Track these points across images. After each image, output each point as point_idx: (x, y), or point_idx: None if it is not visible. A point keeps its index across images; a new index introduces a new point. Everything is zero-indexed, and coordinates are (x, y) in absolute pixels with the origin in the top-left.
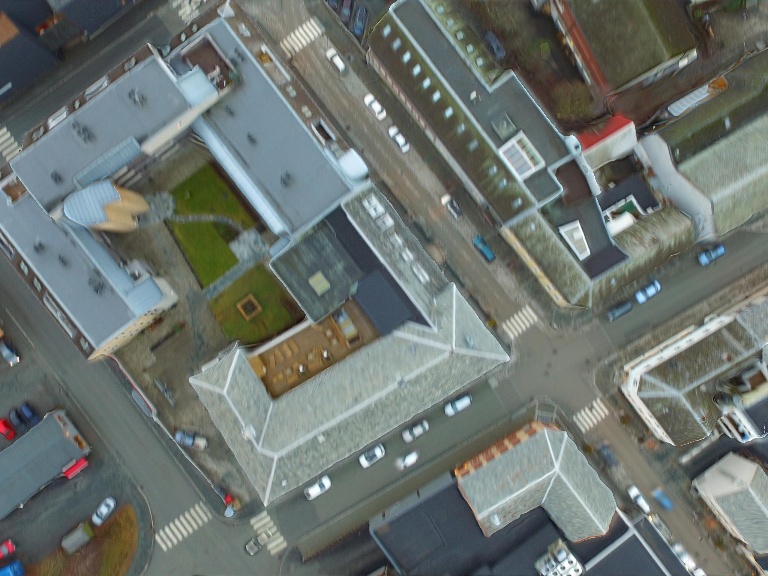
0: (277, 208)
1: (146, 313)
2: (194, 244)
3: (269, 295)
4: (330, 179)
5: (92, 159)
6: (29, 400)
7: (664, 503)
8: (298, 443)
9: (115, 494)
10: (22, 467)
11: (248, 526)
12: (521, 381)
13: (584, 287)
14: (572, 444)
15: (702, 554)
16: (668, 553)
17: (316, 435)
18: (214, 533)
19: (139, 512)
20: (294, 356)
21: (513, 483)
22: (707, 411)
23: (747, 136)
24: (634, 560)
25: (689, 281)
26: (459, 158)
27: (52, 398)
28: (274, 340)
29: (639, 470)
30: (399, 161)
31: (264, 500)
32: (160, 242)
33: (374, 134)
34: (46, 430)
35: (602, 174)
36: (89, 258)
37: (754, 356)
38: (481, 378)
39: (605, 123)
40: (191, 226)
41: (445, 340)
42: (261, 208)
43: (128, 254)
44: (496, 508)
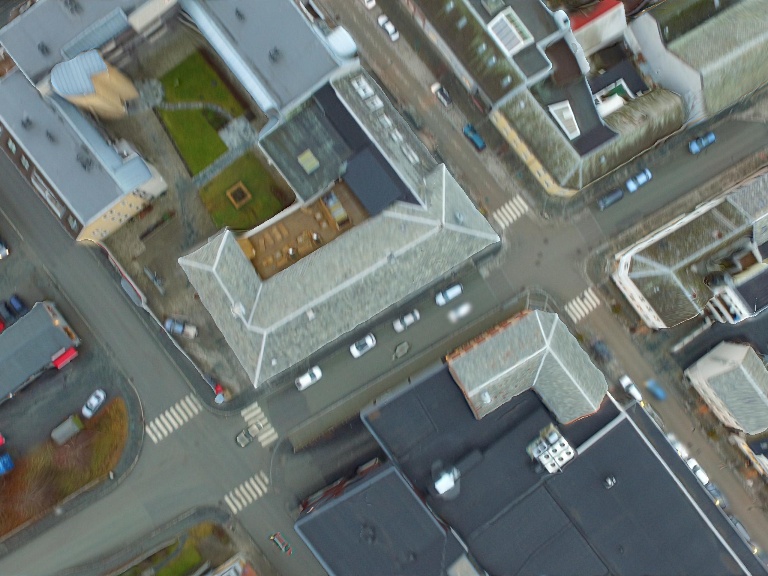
0: (265, 84)
1: (134, 192)
2: (183, 132)
3: (259, 183)
4: (318, 55)
5: (79, 30)
6: (18, 293)
7: (656, 393)
8: (287, 319)
9: (105, 386)
10: (11, 355)
11: (239, 418)
12: (512, 271)
13: (574, 165)
14: (563, 325)
15: (695, 445)
16: (660, 439)
17: (305, 311)
18: (205, 425)
19: (129, 404)
20: (284, 240)
21: (504, 361)
22: (698, 290)
23: (736, 14)
24: (626, 444)
25: (680, 170)
26: (448, 38)
27: (41, 291)
28: (264, 223)
29: (631, 360)
30: (389, 50)
31: (254, 381)
32: (149, 130)
33: (364, 24)
34: (35, 318)
35: (592, 62)
36: (77, 134)
37: (745, 235)
38: (472, 268)
39: (594, 6)
40: (180, 114)
41: (435, 216)
42: (249, 85)
43: (116, 133)
44: (487, 385)
